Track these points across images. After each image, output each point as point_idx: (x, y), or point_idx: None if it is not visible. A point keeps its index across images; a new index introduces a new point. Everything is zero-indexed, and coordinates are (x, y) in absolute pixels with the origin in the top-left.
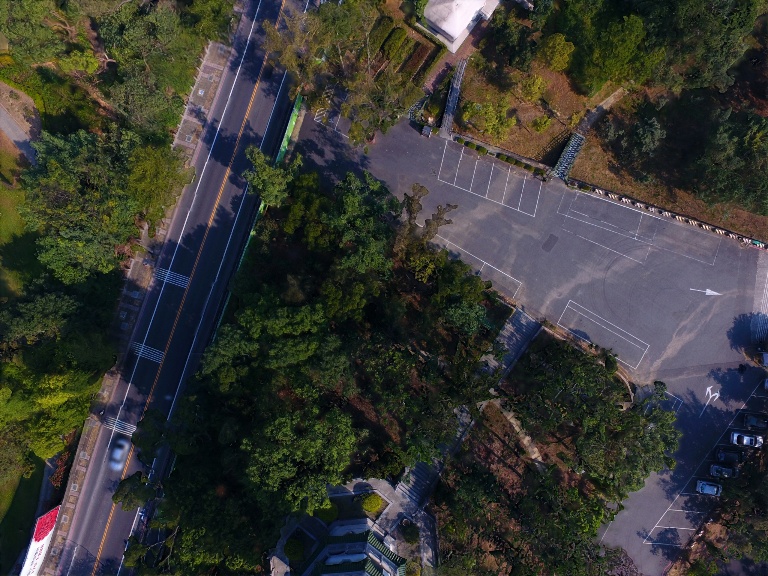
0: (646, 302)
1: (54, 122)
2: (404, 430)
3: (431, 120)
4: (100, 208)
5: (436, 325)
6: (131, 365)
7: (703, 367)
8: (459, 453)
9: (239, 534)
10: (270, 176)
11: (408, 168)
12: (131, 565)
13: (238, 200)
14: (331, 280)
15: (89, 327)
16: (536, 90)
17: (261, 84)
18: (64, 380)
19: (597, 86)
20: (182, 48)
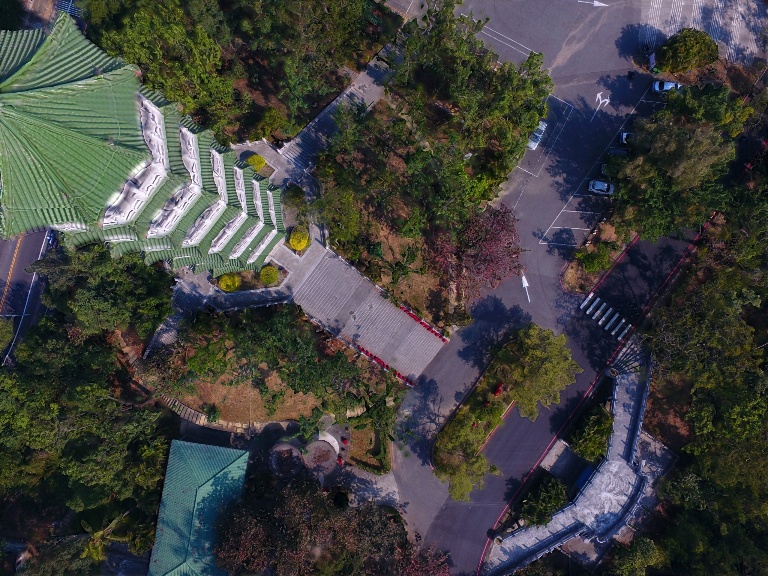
0: (536, 14)
1: None
2: None
3: None
4: None
5: None
6: None
7: (593, 74)
8: None
9: None
10: None
11: None
12: None
13: None
14: None
15: None
16: None
17: None
18: None
19: None
20: None
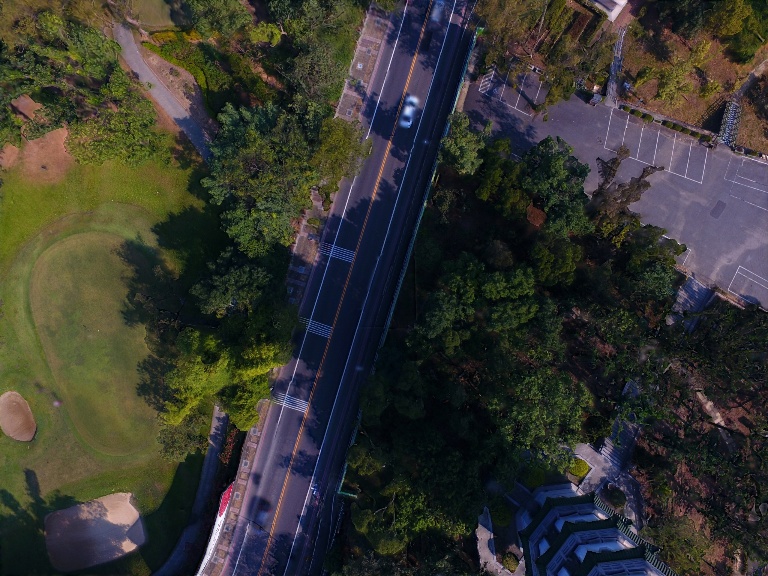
0: None
1: (216, 98)
2: (596, 396)
3: (596, 88)
4: (286, 180)
5: (613, 293)
6: (299, 340)
7: None
8: (652, 418)
9: (475, 496)
10: (467, 143)
11: (574, 137)
12: None
13: (400, 173)
14: (541, 244)
15: (278, 299)
16: (702, 56)
17: (419, 57)
18: (275, 350)
19: (751, 53)
20: (344, 21)
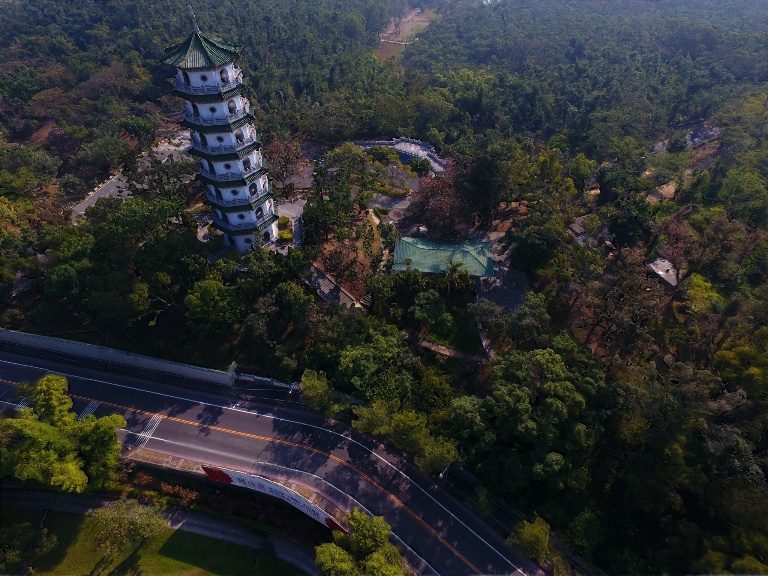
0: None
1: None
2: None
3: None
4: None
5: None
6: None
7: None
8: None
9: None
10: None
11: None
12: None
13: None
14: None
15: None
16: None
17: None
18: (43, 381)
19: None
20: None
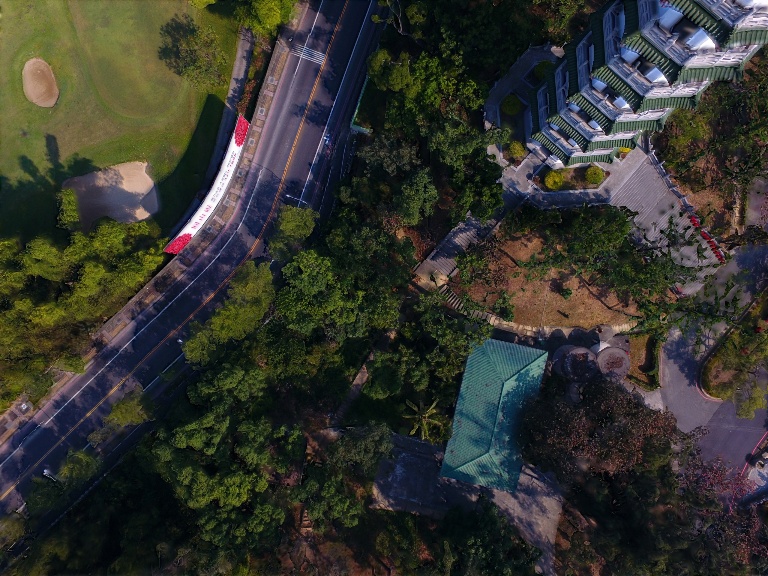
0: None
1: None
2: None
3: None
4: None
5: None
6: None
7: None
8: None
9: None
10: None
11: None
12: (378, 66)
13: None
14: None
15: None
16: None
17: None
18: None
19: None
20: None
